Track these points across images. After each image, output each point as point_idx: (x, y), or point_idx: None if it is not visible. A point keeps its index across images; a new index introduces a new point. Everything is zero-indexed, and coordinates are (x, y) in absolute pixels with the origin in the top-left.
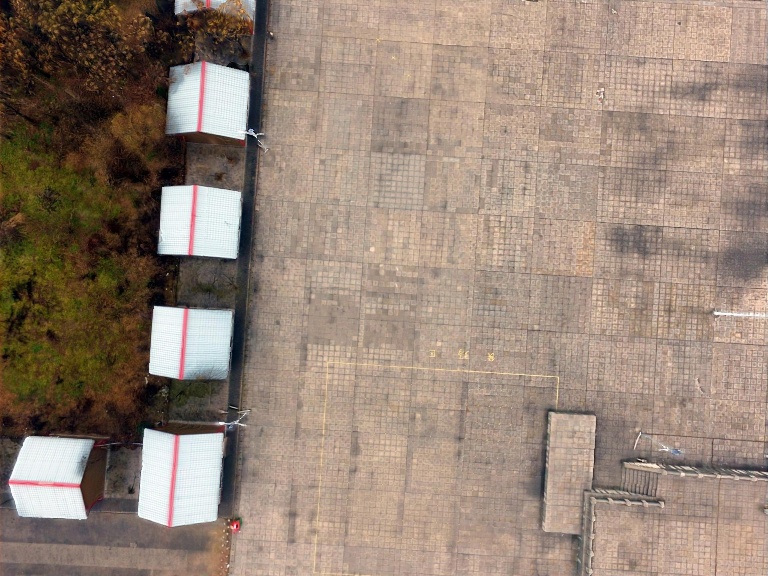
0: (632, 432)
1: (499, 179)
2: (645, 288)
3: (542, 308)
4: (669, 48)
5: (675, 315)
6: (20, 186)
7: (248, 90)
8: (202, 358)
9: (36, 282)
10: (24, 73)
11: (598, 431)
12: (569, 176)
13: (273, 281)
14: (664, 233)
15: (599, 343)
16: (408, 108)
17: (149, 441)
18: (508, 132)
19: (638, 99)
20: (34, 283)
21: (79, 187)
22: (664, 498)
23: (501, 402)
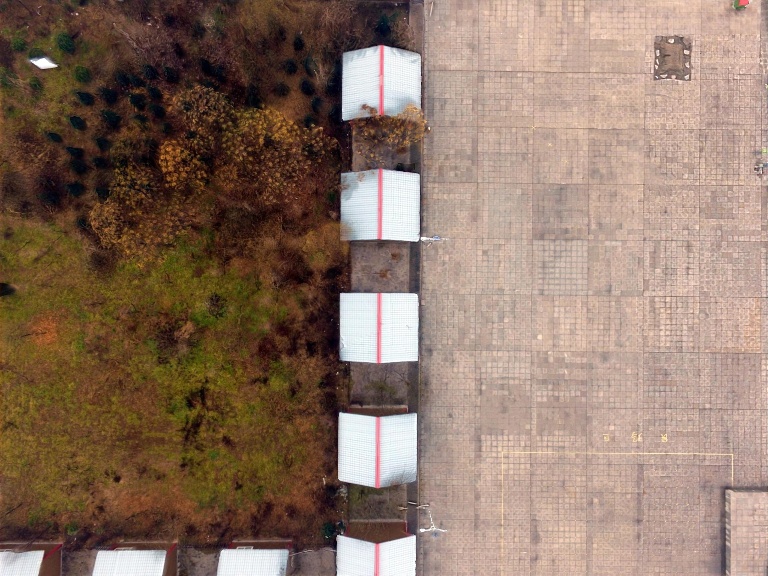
0: None
1: (662, 260)
2: None
3: (712, 386)
4: None
5: None
6: (186, 294)
7: (419, 191)
8: (394, 464)
9: (209, 389)
10: (199, 189)
11: None
12: (732, 253)
13: (443, 374)
14: None
15: None
16: (567, 194)
17: (344, 548)
18: (668, 212)
19: None
20: (207, 390)
21: (245, 292)
22: None
23: (677, 482)
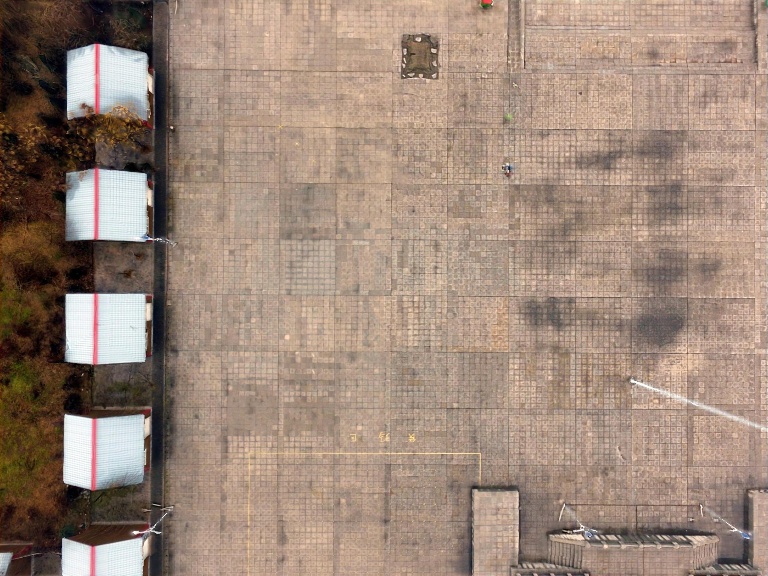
0: (556, 504)
1: (410, 259)
2: (561, 360)
3: (460, 386)
4: (572, 119)
5: (592, 385)
6: None
7: (147, 191)
8: (114, 466)
9: None
10: None
11: (522, 505)
12: (479, 252)
13: (189, 375)
14: (577, 304)
15: (519, 417)
16: (315, 193)
17: (67, 551)
18: (416, 212)
19: (544, 171)
20: None
21: None
22: (589, 570)
23: (424, 482)
